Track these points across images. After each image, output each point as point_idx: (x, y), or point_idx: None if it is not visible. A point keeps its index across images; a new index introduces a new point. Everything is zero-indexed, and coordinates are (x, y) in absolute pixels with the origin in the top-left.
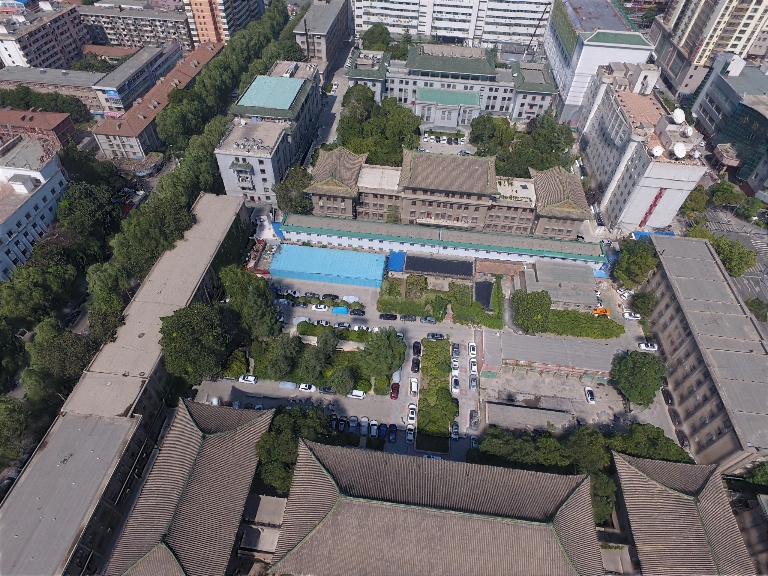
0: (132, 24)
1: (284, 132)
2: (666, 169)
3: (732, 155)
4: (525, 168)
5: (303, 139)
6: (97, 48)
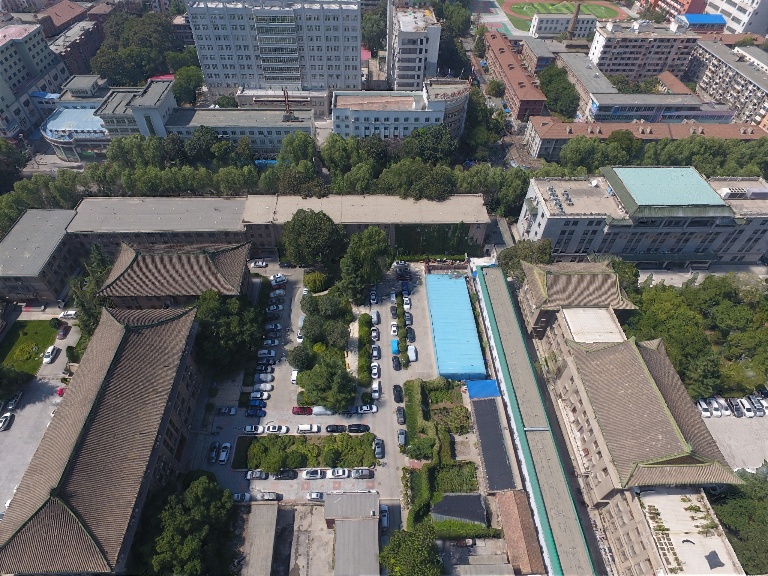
0: (731, 76)
1: (604, 217)
2: None
3: None
4: None
5: (649, 253)
6: (672, 79)
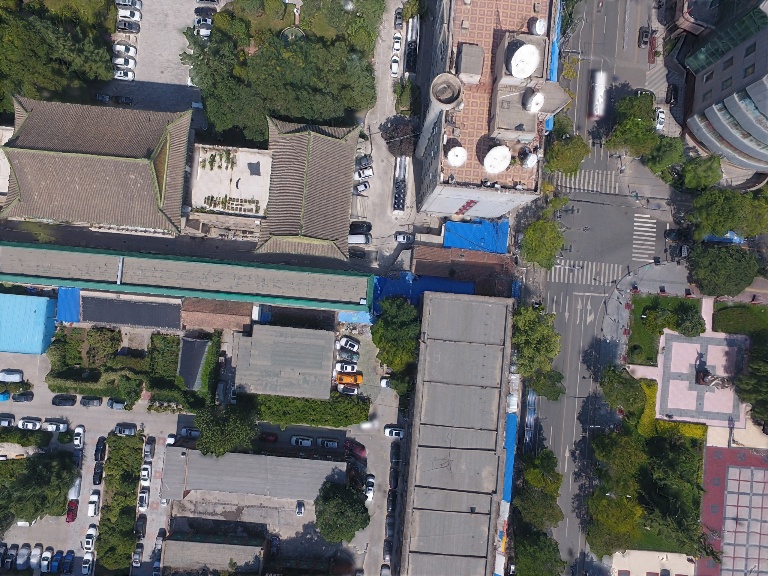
0: None
1: None
2: (467, 192)
3: (706, 0)
4: (261, 118)
5: None
6: None
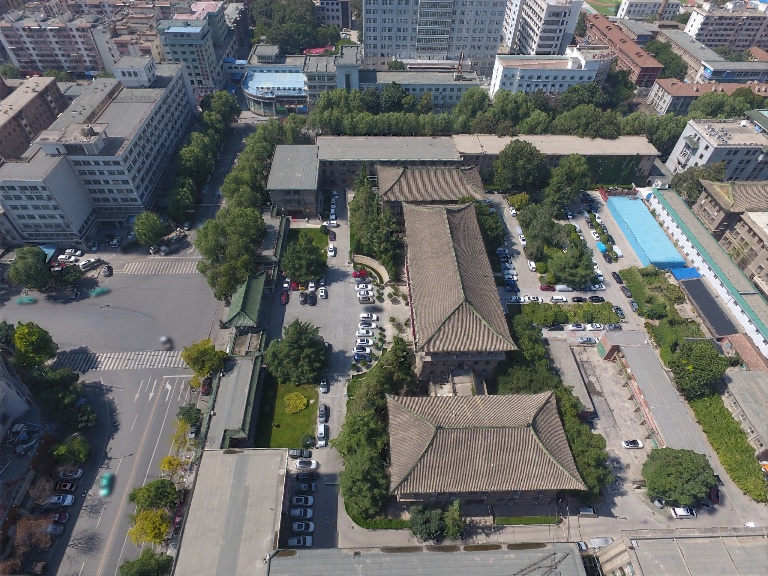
0: None
1: (761, 147)
2: None
3: None
4: None
5: None
6: (761, 52)
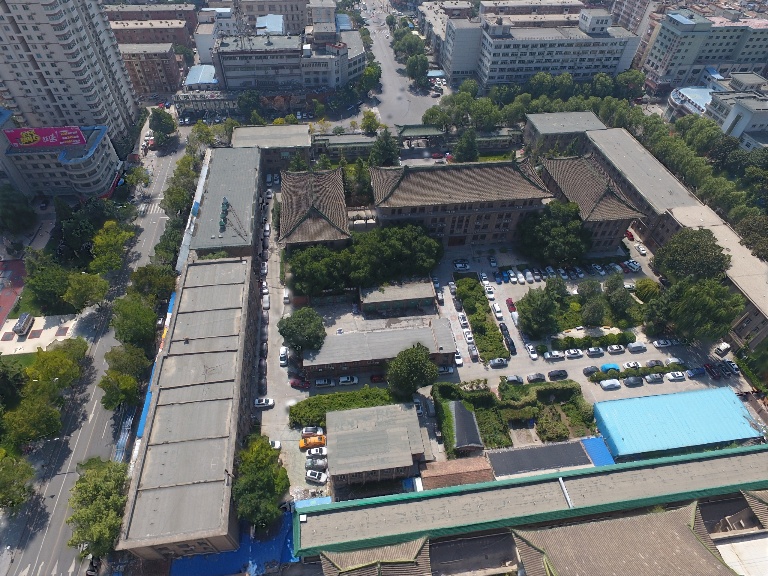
0: None
1: None
2: None
3: None
4: None
5: None
6: None
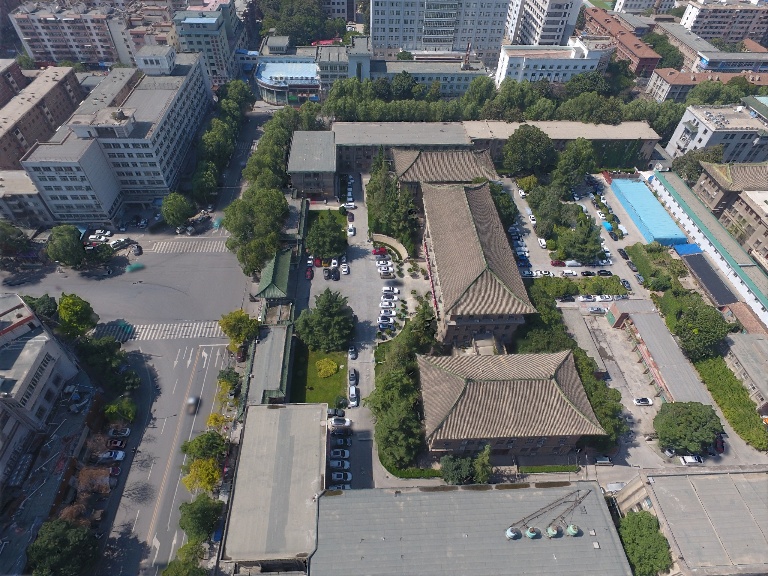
0: None
1: (756, 131)
2: None
3: None
4: None
5: None
6: (754, 44)
